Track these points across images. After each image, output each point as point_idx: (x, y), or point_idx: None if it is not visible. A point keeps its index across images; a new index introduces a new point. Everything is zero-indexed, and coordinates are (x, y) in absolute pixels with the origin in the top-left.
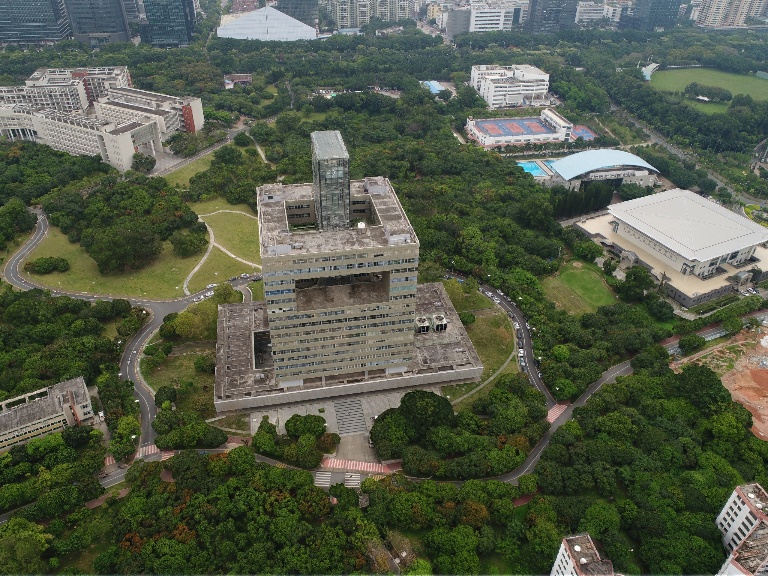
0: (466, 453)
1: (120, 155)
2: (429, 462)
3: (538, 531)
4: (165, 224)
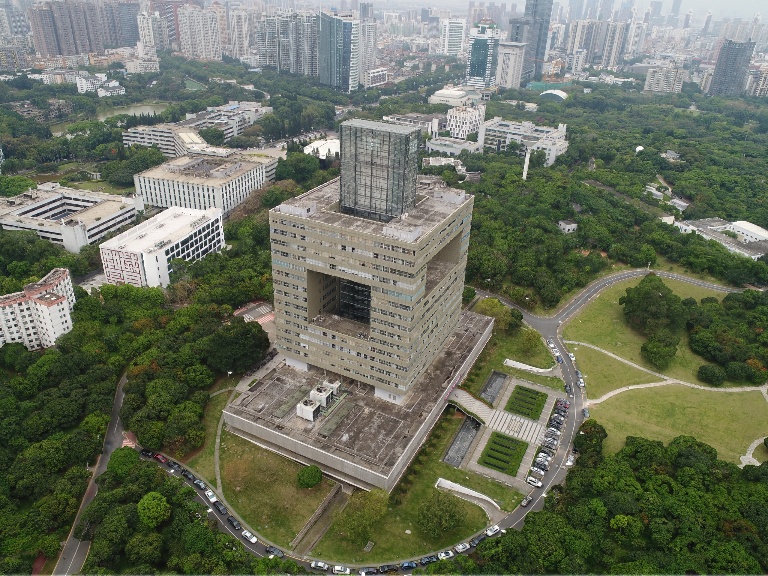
0: None
1: None
2: None
3: None
4: (713, 343)
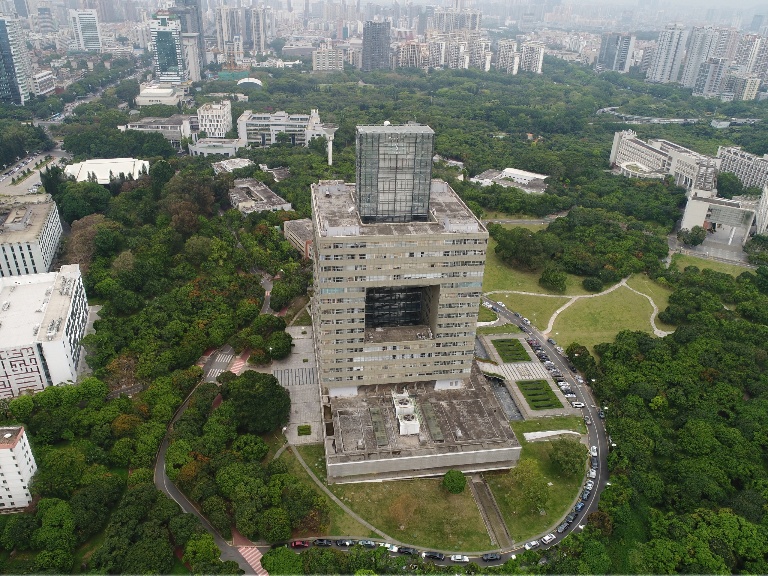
0: (203, 435)
1: (684, 219)
2: (194, 397)
3: (68, 449)
4: (579, 261)
